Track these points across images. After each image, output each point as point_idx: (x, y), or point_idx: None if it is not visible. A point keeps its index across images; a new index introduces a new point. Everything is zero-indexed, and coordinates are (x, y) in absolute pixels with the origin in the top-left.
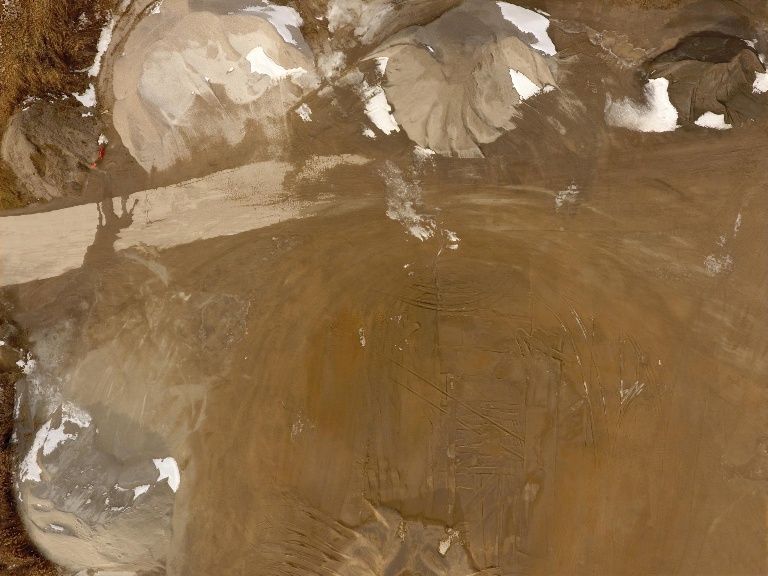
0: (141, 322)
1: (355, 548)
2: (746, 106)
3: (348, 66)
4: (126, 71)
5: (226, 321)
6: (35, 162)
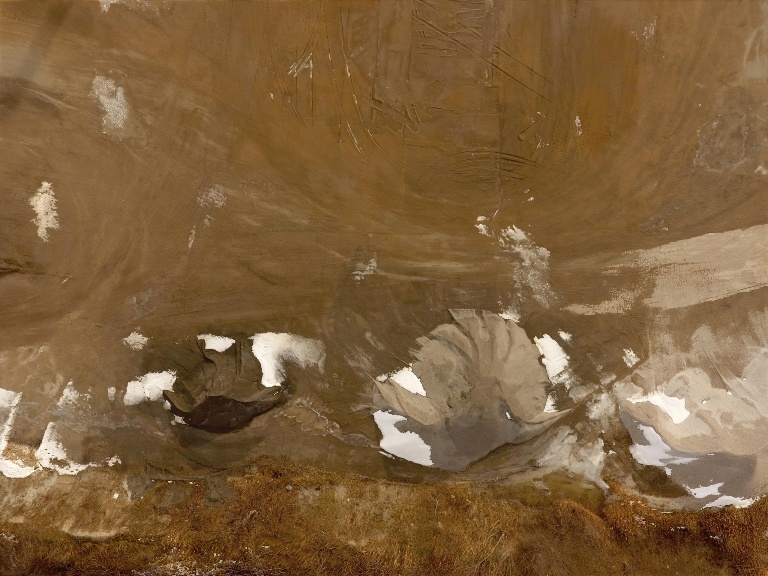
0: None
1: None
2: (183, 357)
3: (585, 404)
4: None
5: (719, 144)
6: None
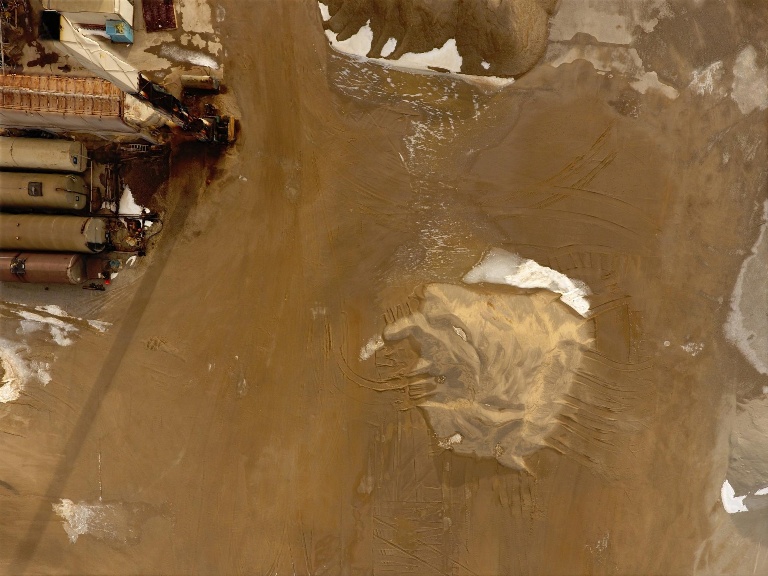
0: None
1: (545, 431)
2: None
3: None
4: None
5: None
6: None
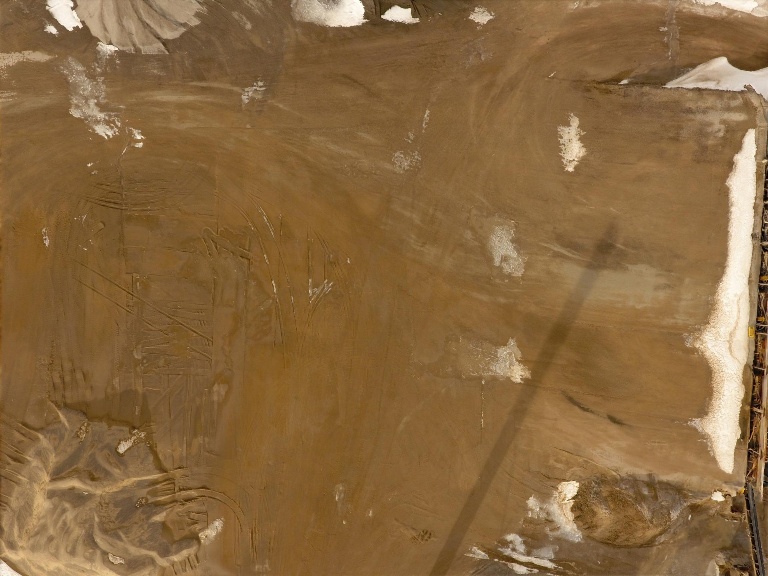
0: None
1: (37, 449)
2: None
3: None
4: None
5: None
6: None
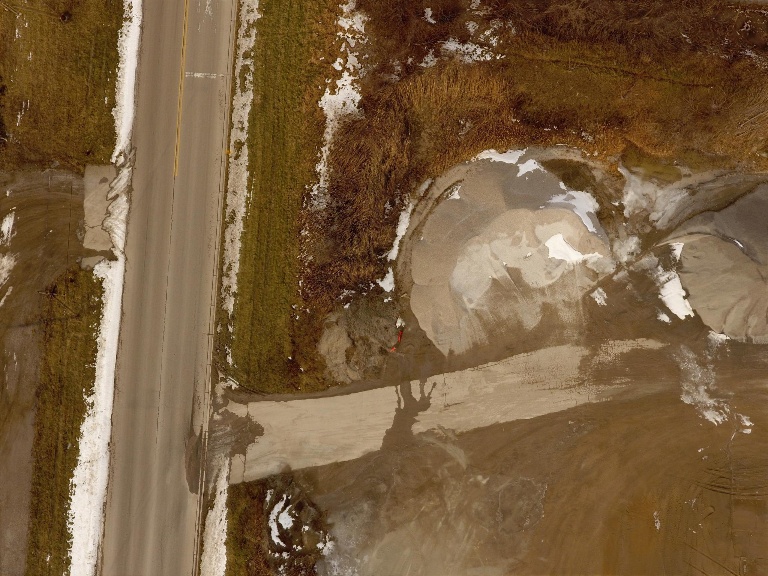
0: (439, 505)
1: None
2: None
3: (643, 251)
4: (433, 260)
5: (523, 504)
6: (347, 353)
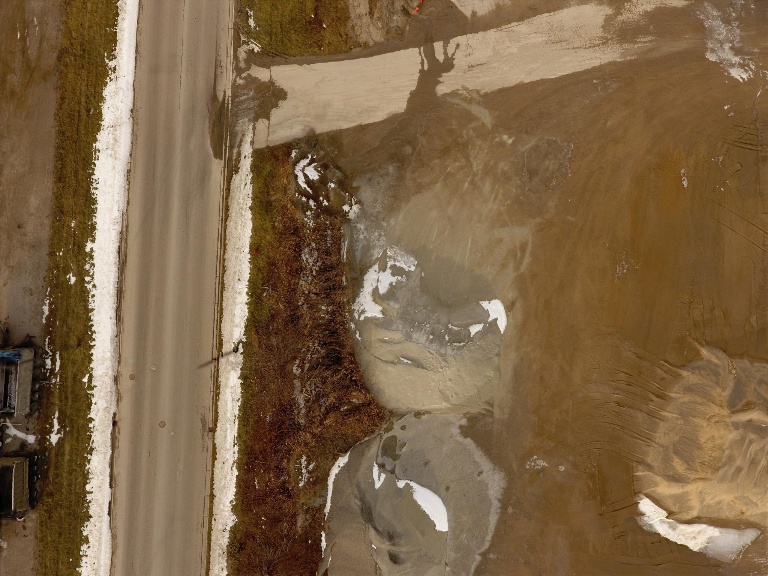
0: (465, 165)
1: (684, 386)
2: None
3: None
4: None
5: (549, 164)
6: (370, 1)
